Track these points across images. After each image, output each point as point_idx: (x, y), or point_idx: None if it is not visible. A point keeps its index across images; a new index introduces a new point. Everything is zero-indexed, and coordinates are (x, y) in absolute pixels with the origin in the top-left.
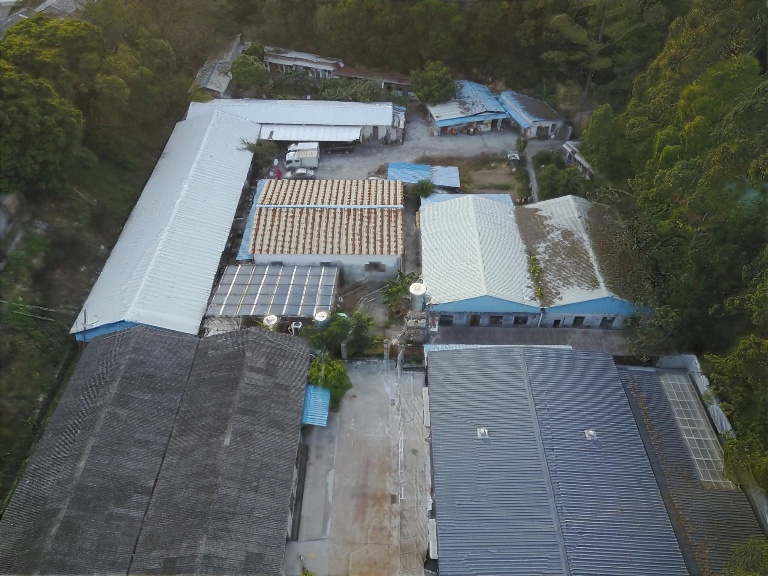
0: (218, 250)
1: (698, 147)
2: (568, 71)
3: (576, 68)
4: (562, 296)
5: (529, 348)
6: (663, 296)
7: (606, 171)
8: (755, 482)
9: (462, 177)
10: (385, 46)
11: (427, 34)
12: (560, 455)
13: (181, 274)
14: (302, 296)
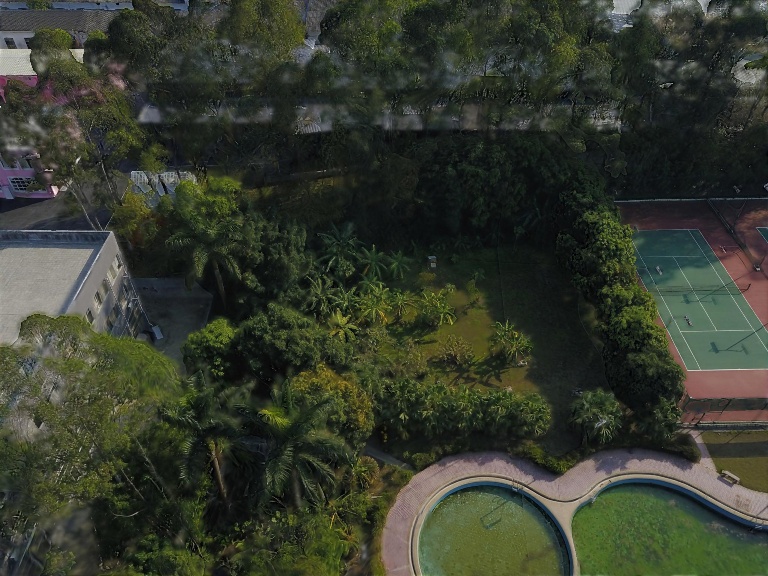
0: None
1: None
2: None
3: None
4: None
5: None
6: None
7: None
8: None
9: None
10: None
11: None
12: None
13: (619, 3)
14: None
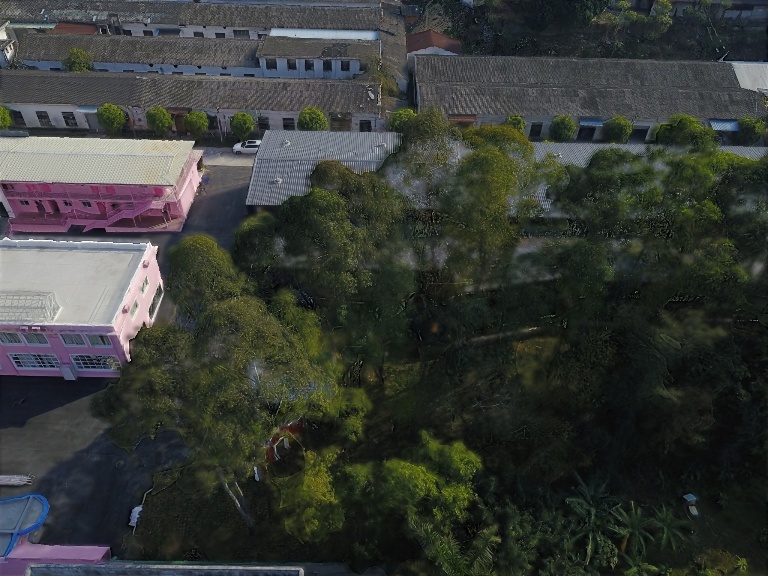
0: None
1: None
2: None
3: None
4: None
5: None
6: None
7: None
8: None
9: None
10: None
11: None
12: None
13: None
14: None
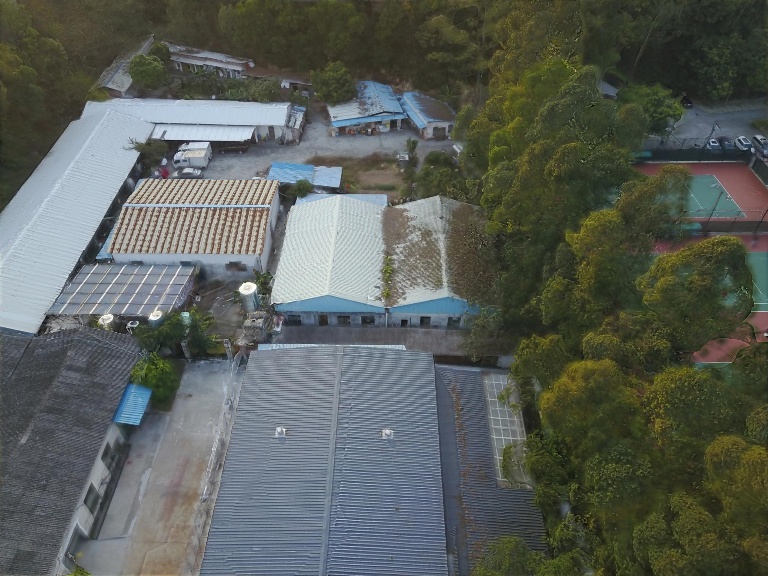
0: (79, 249)
1: (520, 148)
2: (459, 72)
3: (465, 69)
4: (407, 296)
5: (349, 348)
6: (495, 296)
7: (472, 172)
8: (526, 481)
9: (349, 177)
10: (289, 46)
11: (328, 35)
12: (350, 454)
13: (32, 273)
14: (148, 295)
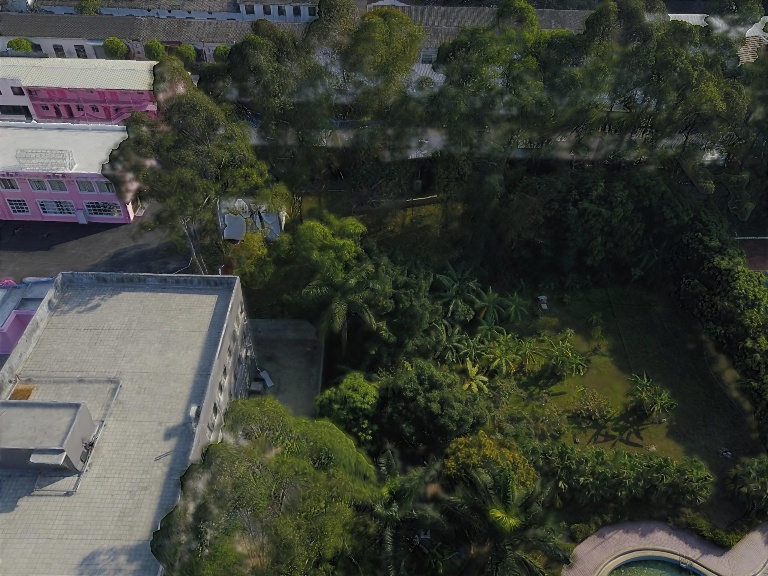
0: None
1: None
2: None
3: None
4: None
5: None
6: None
7: None
8: None
9: None
10: None
11: None
12: None
13: None
14: None
